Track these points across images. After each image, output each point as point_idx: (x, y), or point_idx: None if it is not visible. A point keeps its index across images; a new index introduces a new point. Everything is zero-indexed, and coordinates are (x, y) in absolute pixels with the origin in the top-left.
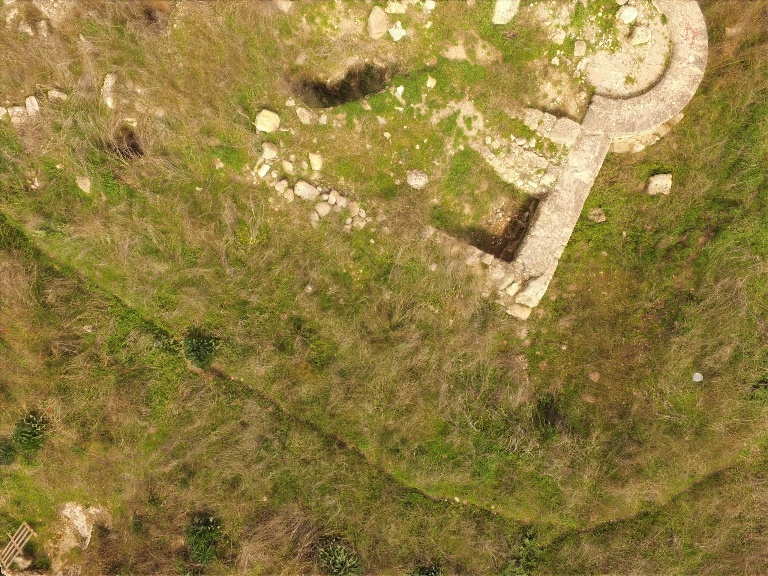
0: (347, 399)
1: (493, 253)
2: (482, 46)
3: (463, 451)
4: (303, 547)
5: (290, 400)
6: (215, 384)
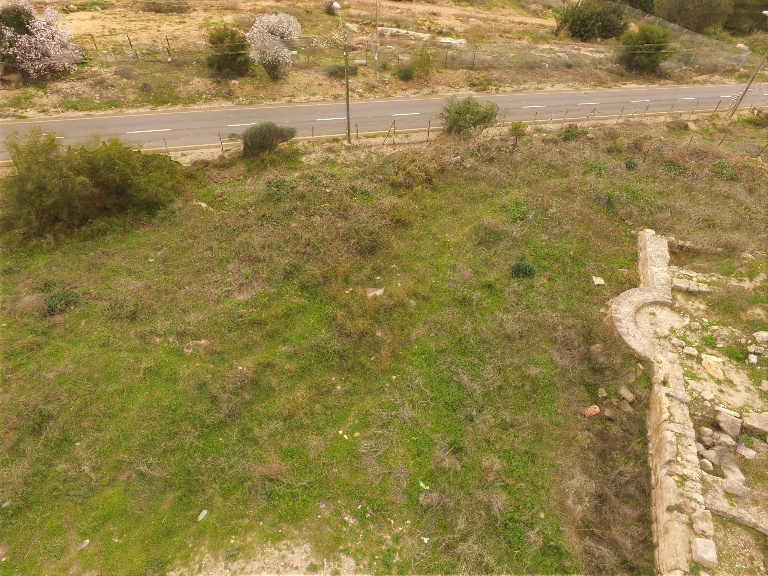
0: (709, 203)
1: (671, 255)
2: (761, 315)
3: (644, 192)
4: (690, 170)
5: (733, 204)
6: (767, 212)
